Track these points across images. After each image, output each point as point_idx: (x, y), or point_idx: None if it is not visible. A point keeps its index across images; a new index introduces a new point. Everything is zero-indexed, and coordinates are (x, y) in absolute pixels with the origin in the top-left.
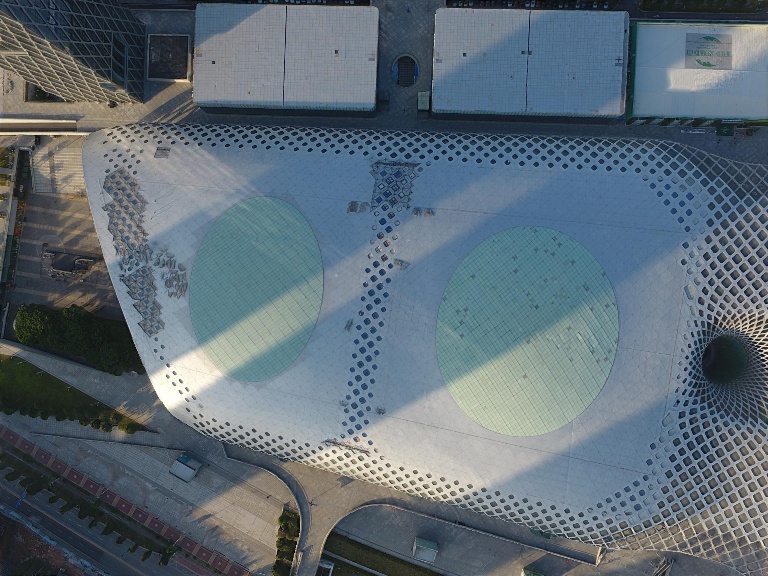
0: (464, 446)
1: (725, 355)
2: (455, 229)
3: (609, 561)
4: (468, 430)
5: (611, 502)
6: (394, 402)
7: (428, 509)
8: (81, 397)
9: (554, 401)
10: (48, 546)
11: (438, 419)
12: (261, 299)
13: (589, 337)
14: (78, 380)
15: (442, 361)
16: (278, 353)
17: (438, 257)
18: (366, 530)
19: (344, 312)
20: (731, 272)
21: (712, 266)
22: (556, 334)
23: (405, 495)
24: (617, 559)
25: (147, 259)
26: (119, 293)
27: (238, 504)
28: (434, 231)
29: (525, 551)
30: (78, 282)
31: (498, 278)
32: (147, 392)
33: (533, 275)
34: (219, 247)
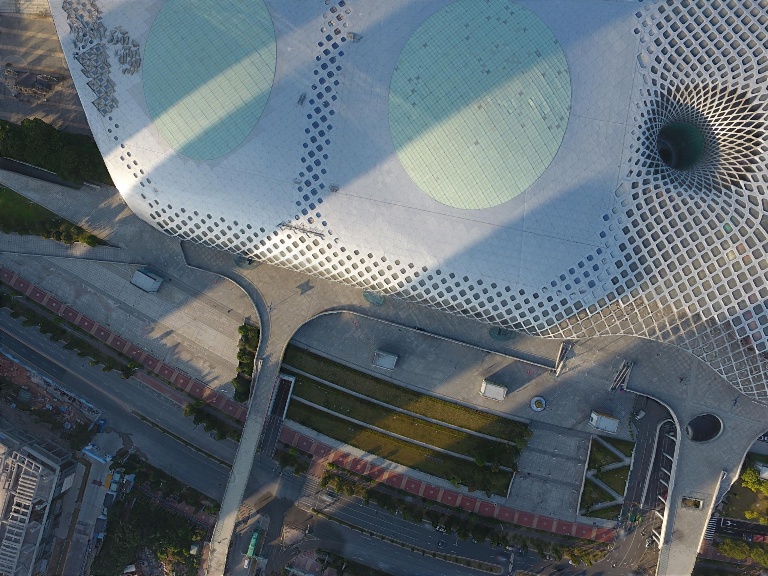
0: (418, 223)
1: (684, 153)
2: (408, 2)
3: (570, 369)
4: (421, 205)
5: (565, 279)
6: (347, 178)
7: (388, 315)
8: (43, 213)
9: (506, 169)
10: (11, 364)
11: (391, 194)
12: (214, 72)
13: (541, 103)
14: (40, 196)
15: (394, 132)
16: (231, 128)
17: (391, 29)
18: (327, 343)
19: (297, 86)
20: (684, 41)
21: (665, 35)
22: (507, 99)
23: (365, 302)
24: (577, 366)
25: (101, 36)
26: (73, 71)
27: (200, 319)
28: (387, 4)
29: (486, 362)
30: (41, 102)
31: (450, 45)
32: (109, 207)
33: (485, 41)
34: (172, 22)
